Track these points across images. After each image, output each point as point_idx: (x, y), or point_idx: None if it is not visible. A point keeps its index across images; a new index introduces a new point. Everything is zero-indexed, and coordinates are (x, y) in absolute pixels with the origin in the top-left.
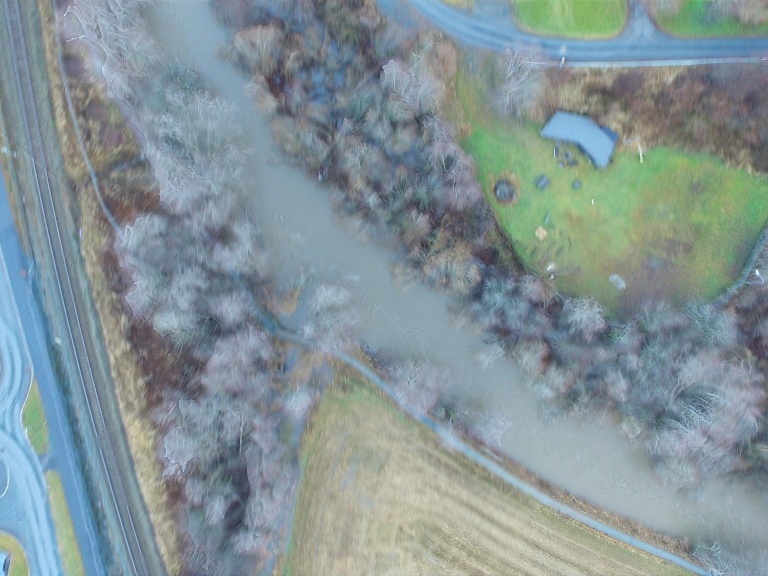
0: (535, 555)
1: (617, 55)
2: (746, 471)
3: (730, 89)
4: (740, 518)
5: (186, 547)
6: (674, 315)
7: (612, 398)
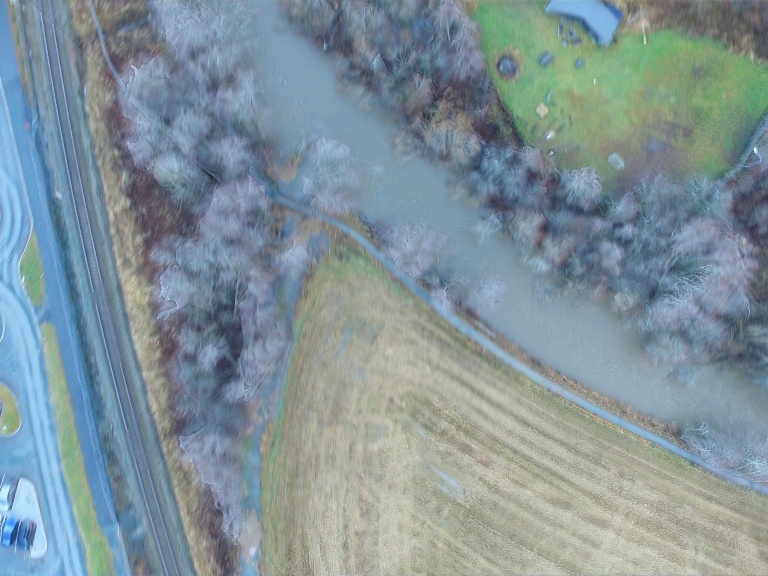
0: (524, 432)
1: None
2: (737, 358)
3: None
4: (729, 401)
5: (177, 405)
6: (671, 185)
7: (606, 272)
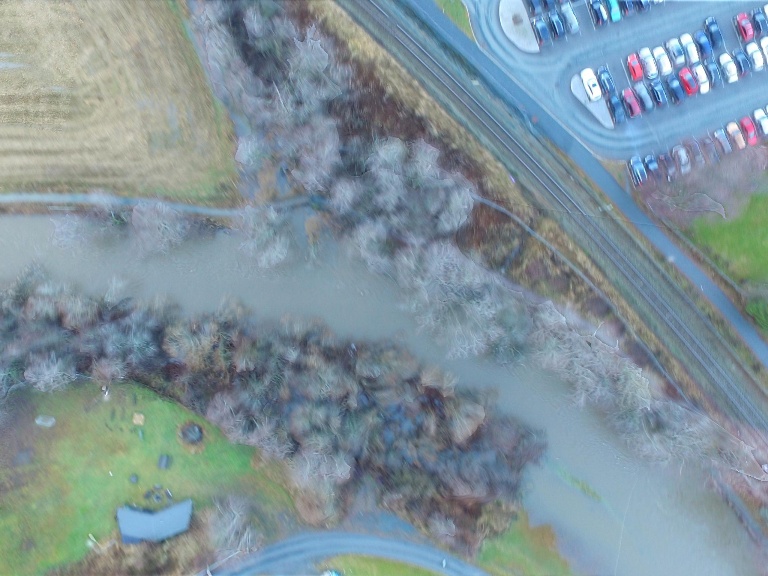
0: None
1: None
2: None
3: None
4: None
5: None
6: None
7: None
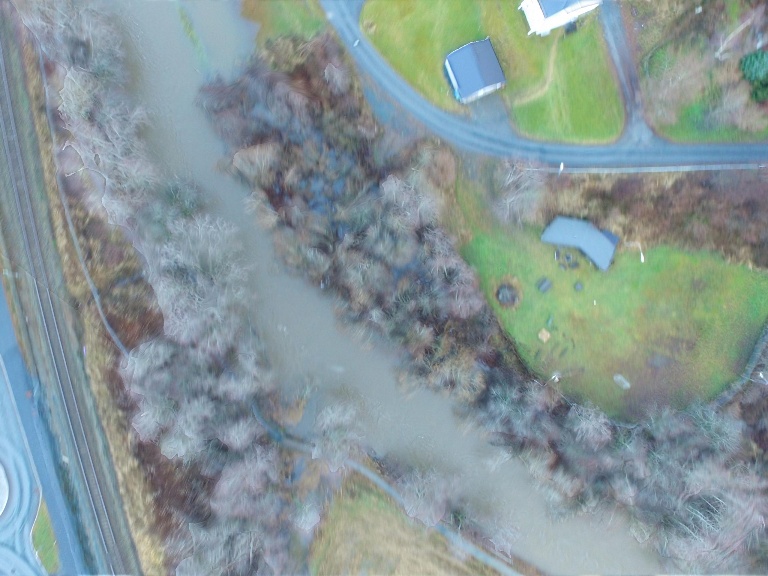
0: None
1: (616, 161)
2: (755, 564)
3: (729, 195)
4: None
5: None
6: (680, 423)
7: (620, 501)
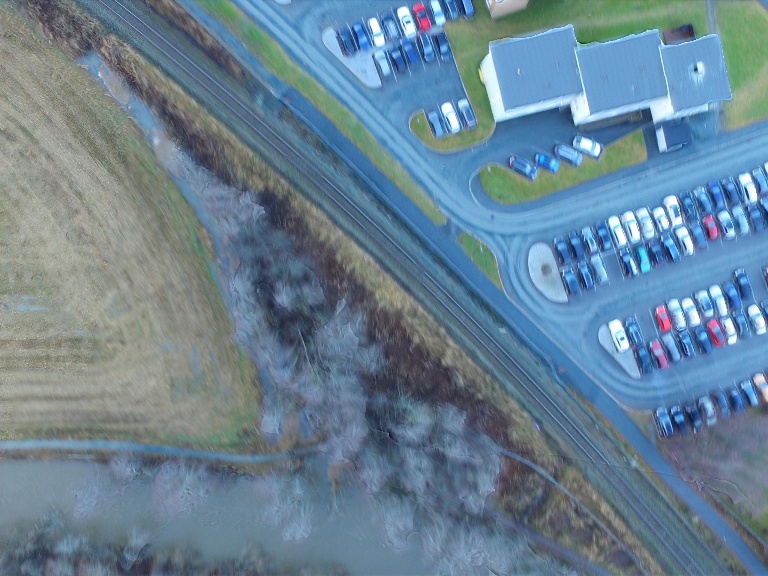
0: None
1: None
2: None
3: None
4: None
5: (296, 225)
6: None
7: None
